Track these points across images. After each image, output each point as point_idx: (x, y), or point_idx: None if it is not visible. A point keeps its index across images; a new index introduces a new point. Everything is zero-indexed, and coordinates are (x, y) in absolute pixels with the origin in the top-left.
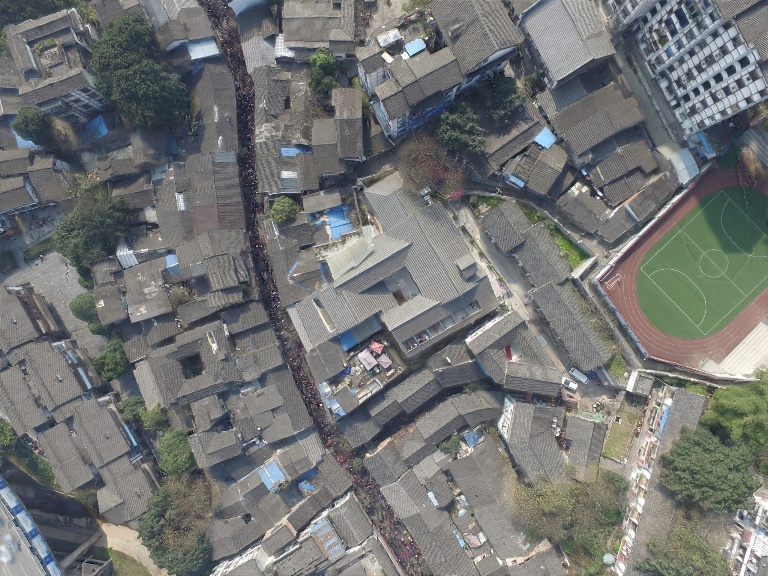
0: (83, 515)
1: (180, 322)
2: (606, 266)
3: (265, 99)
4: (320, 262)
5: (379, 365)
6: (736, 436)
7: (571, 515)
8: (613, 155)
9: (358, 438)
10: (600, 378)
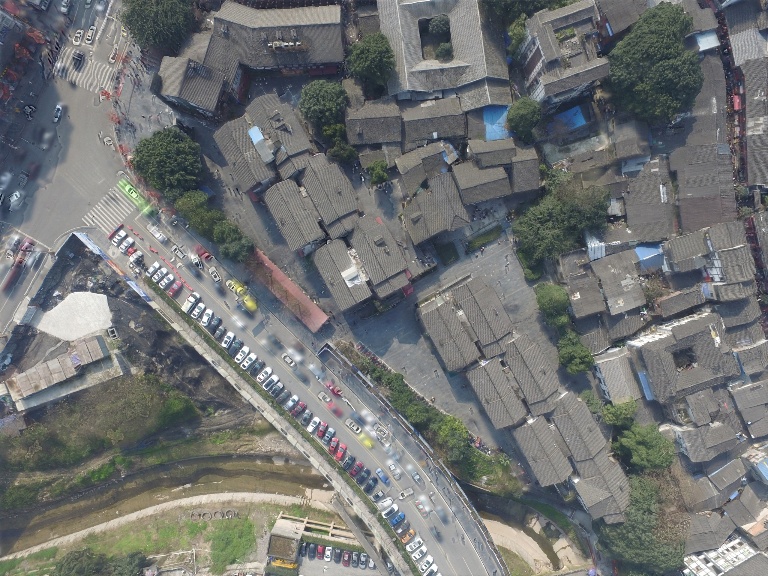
0: None
1: (646, 315)
2: None
3: (764, 91)
4: None
5: None
6: None
7: None
8: None
9: None
10: None
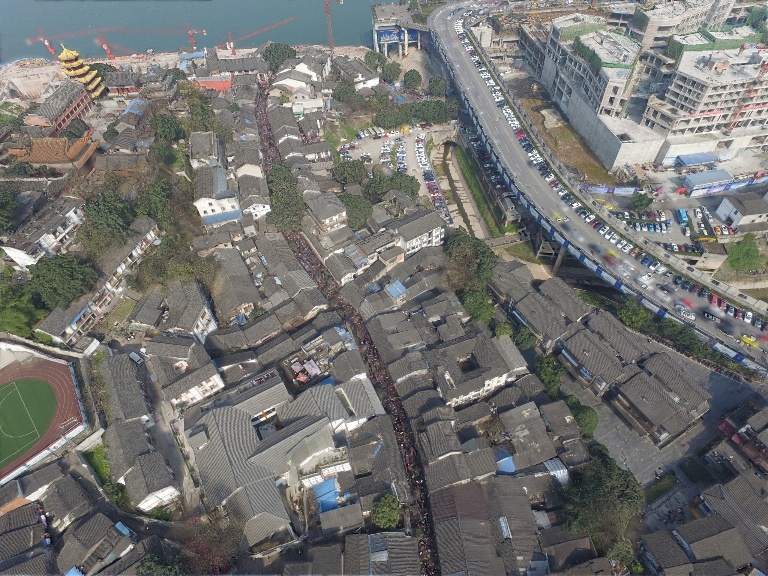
0: None
1: (492, 407)
2: (70, 439)
3: None
4: None
5: None
6: (27, 295)
7: None
8: (7, 557)
9: (329, 316)
10: None
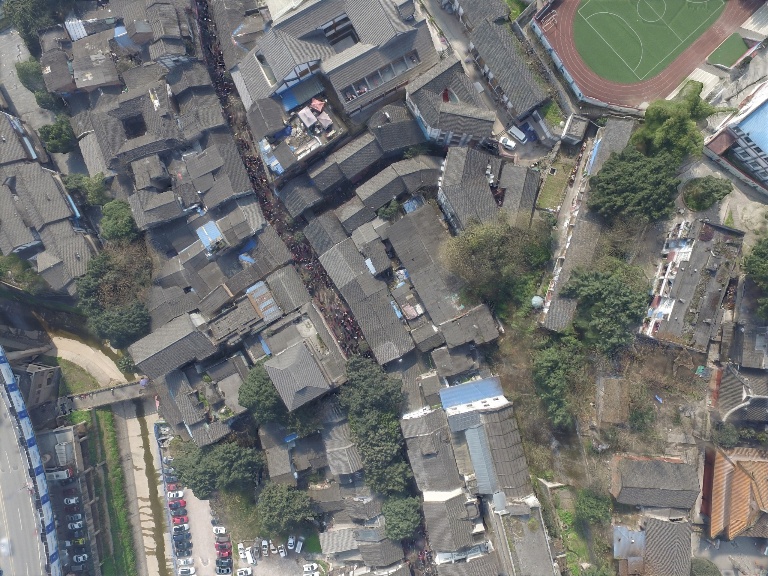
0: (35, 328)
1: None
2: None
3: None
4: (264, 21)
5: (320, 127)
6: (658, 140)
7: (499, 248)
8: None
9: (298, 204)
10: (538, 134)
